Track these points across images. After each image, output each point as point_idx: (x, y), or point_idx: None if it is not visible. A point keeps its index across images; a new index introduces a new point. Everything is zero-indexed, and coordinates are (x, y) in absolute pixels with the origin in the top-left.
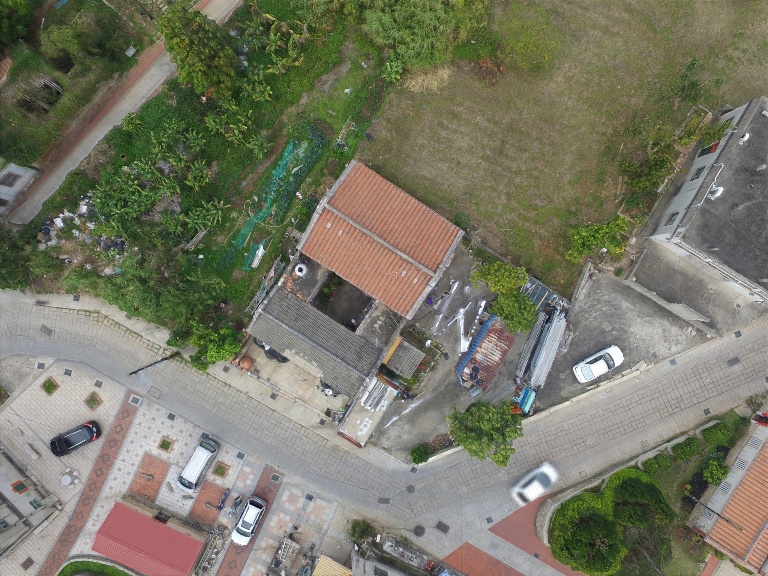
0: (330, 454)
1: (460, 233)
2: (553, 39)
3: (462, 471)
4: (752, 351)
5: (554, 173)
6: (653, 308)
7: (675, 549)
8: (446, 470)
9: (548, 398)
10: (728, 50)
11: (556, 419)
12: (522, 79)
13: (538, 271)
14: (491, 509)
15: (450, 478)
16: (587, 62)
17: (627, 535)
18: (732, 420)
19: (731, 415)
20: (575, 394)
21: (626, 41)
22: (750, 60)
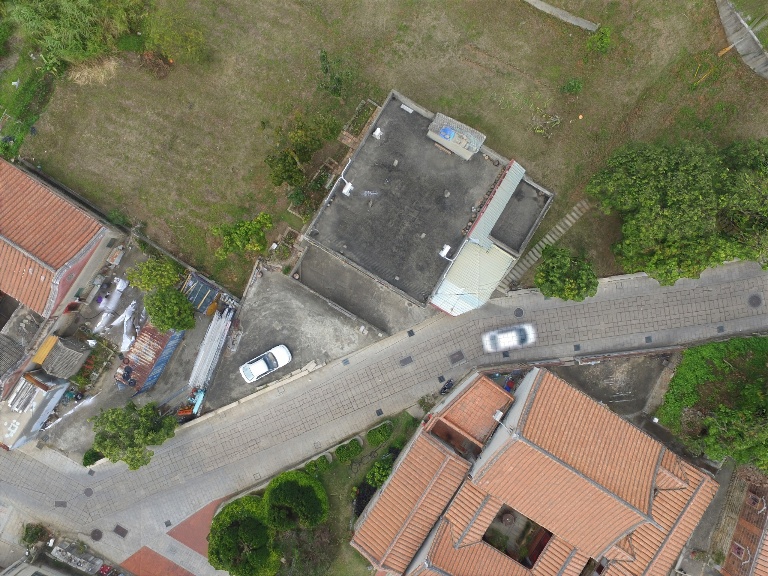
0: (5, 456)
1: (101, 230)
2: (192, 30)
3: (140, 473)
4: (425, 350)
5: (226, 168)
6: (324, 307)
7: (346, 552)
8: (124, 472)
9: (218, 399)
10: (394, 43)
11: (230, 420)
12: (194, 72)
13: (211, 269)
14: (169, 512)
15: (128, 481)
16: (256, 55)
17: (280, 539)
18: (405, 421)
19: (404, 416)
20: (245, 395)
21: (296, 33)
22: (415, 53)
